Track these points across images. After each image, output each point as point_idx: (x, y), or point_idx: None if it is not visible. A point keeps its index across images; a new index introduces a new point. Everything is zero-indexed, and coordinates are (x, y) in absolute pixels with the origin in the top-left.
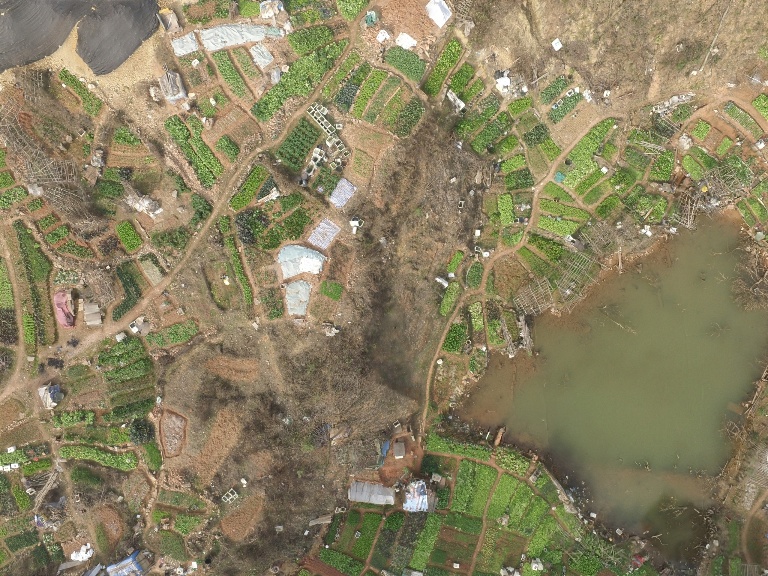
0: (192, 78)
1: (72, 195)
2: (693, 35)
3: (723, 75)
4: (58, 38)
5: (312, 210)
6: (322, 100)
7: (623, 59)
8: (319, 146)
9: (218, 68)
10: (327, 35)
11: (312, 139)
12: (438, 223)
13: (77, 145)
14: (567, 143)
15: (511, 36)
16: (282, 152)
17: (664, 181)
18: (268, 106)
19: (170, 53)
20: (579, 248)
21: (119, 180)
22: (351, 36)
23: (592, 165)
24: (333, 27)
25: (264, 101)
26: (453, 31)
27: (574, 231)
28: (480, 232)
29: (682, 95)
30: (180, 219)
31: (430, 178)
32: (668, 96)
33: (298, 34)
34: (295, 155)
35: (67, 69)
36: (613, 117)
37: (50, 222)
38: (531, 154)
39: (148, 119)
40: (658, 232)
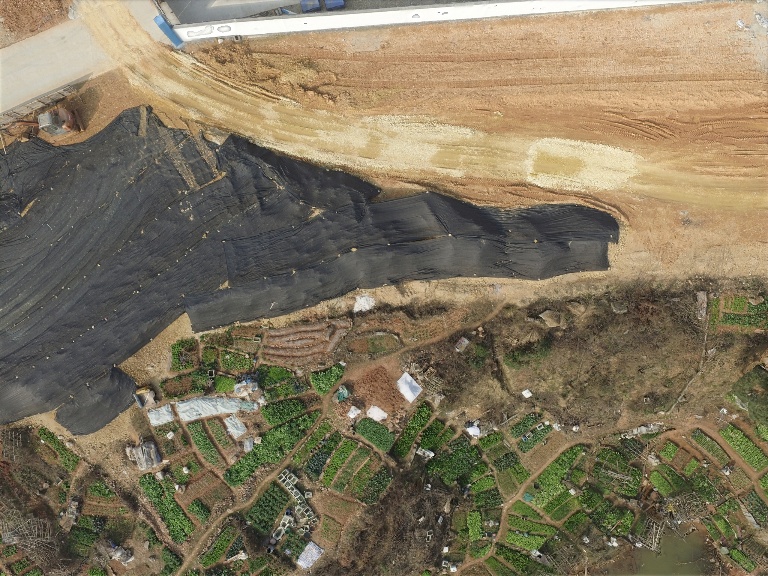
0: (167, 448)
1: (46, 546)
2: (660, 390)
3: (691, 411)
4: (38, 409)
5: (280, 570)
6: (293, 466)
7: (592, 405)
8: (288, 513)
9: (192, 438)
10: (300, 409)
11: (282, 505)
12: (405, 560)
13: (54, 490)
14: (536, 468)
15: (481, 396)
16: (252, 516)
17: (631, 497)
18: (240, 474)
19: (146, 421)
20: (545, 563)
21: (93, 528)
22: (323, 407)
23: (560, 487)
24: (306, 400)
25: (236, 469)
26: (424, 399)
27: (541, 545)
28: (448, 547)
29: (650, 424)
30: (151, 568)
31: (397, 528)
32: (637, 425)
33: (271, 408)
34: (265, 519)
35: (46, 427)
36: (582, 443)
37: (24, 565)
38: (501, 476)
39: (123, 474)
40: (624, 543)
